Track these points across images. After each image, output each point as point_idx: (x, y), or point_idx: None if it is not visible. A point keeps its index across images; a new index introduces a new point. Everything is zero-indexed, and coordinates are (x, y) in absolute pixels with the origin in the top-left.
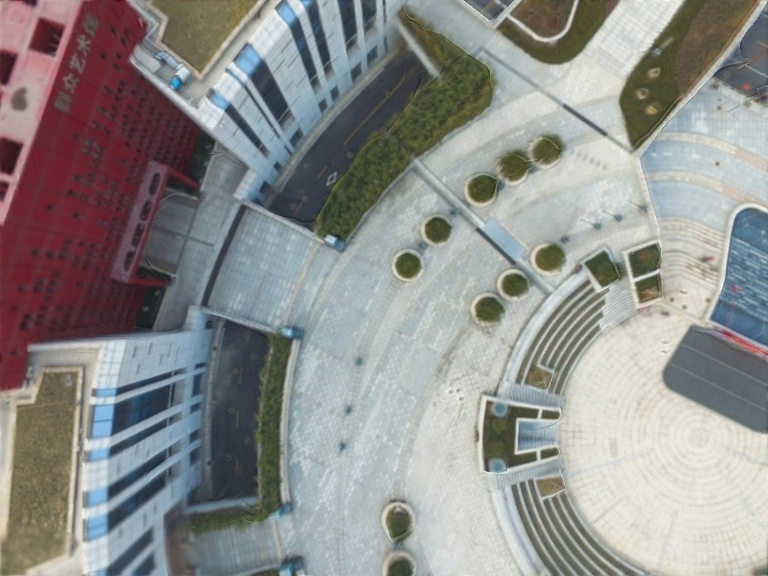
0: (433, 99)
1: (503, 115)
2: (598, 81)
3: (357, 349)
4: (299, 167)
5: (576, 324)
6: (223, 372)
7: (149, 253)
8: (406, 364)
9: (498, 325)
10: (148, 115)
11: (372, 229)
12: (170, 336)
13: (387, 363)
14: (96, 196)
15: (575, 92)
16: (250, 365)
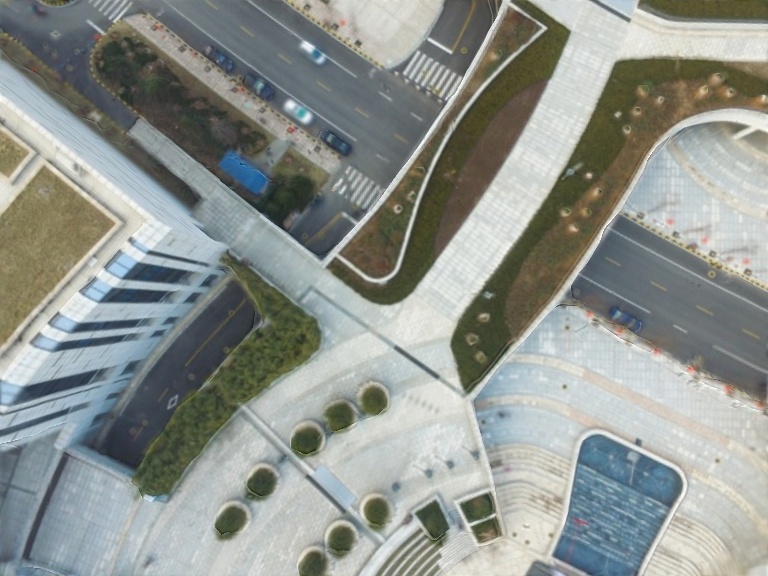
0: (250, 356)
1: (333, 357)
2: (429, 322)
3: None
4: (139, 390)
5: (412, 568)
6: None
7: None
8: None
9: None
10: None
11: (199, 477)
12: None
13: None
14: None
15: (407, 333)
16: None
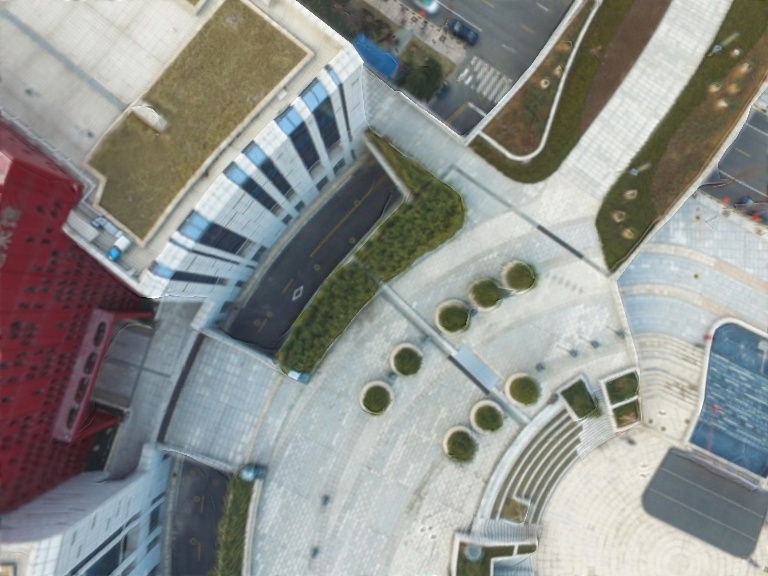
0: (401, 228)
1: (475, 236)
2: (573, 201)
3: (324, 486)
4: (263, 280)
5: (553, 452)
6: (184, 500)
7: (99, 389)
8: (376, 501)
9: (472, 458)
10: (88, 276)
11: (339, 358)
12: (119, 493)
13: (356, 500)
14: (29, 370)
15: (550, 212)
16: (211, 499)
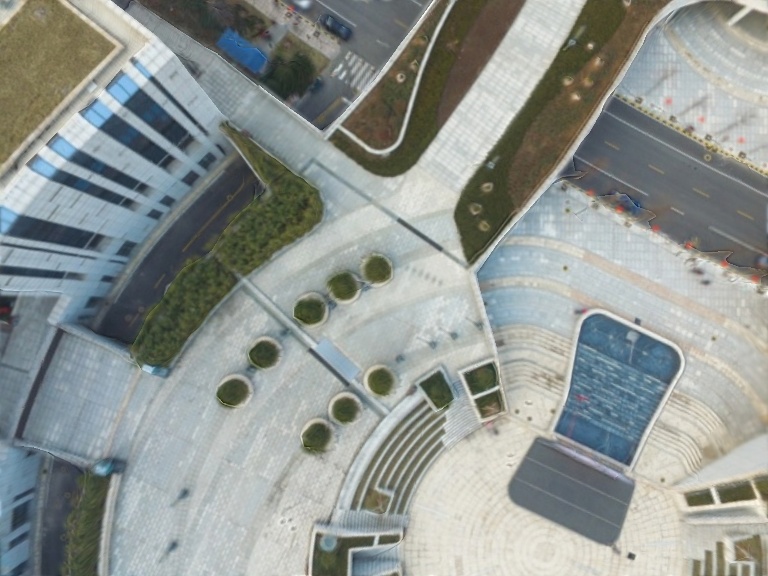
0: (252, 221)
1: (336, 230)
2: (433, 194)
3: (183, 480)
4: (135, 276)
5: (416, 443)
6: (54, 496)
7: None
8: (235, 494)
9: (331, 450)
10: None
11: (199, 352)
12: None
13: (215, 494)
14: None
15: (410, 205)
16: None
